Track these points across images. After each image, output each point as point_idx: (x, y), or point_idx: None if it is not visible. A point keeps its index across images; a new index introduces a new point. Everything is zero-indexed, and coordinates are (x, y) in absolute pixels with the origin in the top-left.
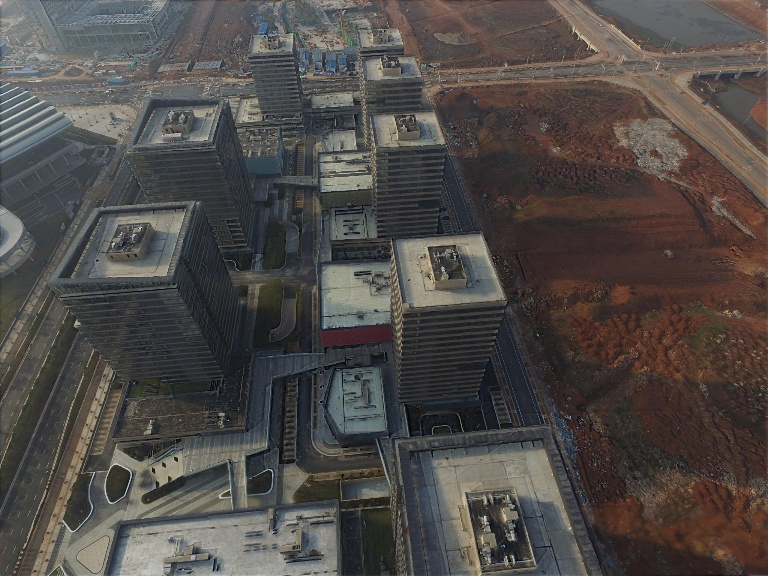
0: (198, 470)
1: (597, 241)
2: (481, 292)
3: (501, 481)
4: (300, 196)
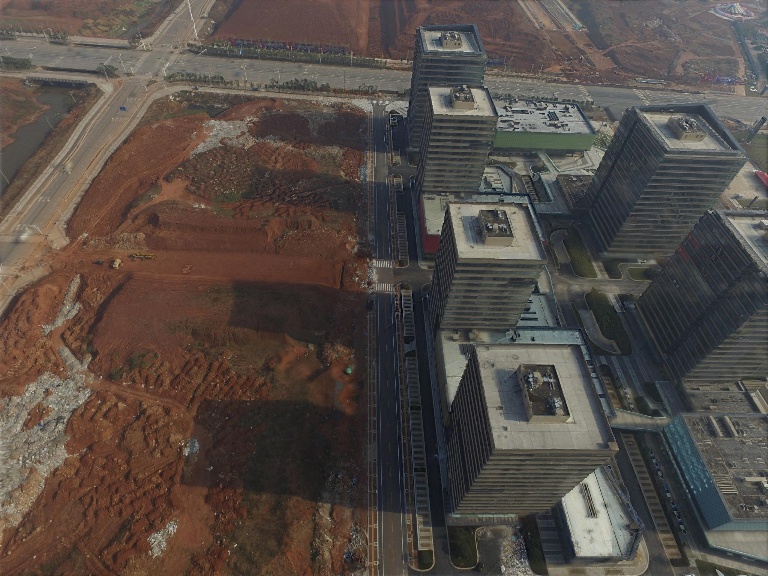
0: (574, 169)
1: (254, 281)
2: (441, 91)
3: (446, 49)
4: (613, 402)
